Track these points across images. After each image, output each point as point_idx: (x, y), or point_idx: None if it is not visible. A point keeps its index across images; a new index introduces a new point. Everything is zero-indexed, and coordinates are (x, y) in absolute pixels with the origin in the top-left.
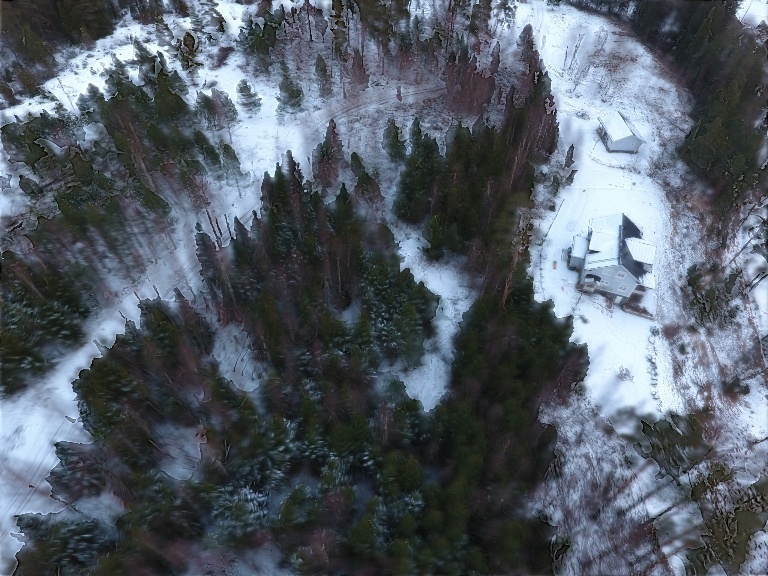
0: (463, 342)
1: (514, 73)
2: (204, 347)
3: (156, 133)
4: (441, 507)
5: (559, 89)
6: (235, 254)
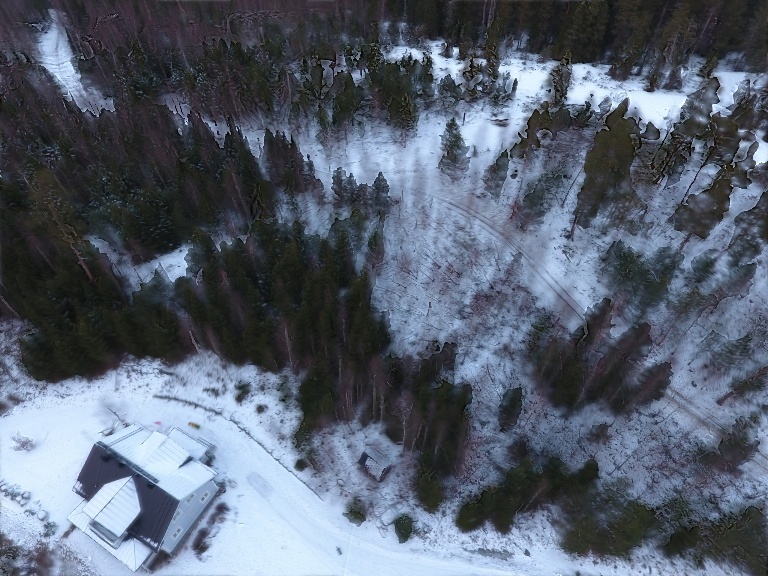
0: None
1: None
2: (177, 152)
3: (345, 86)
4: None
5: None
6: None
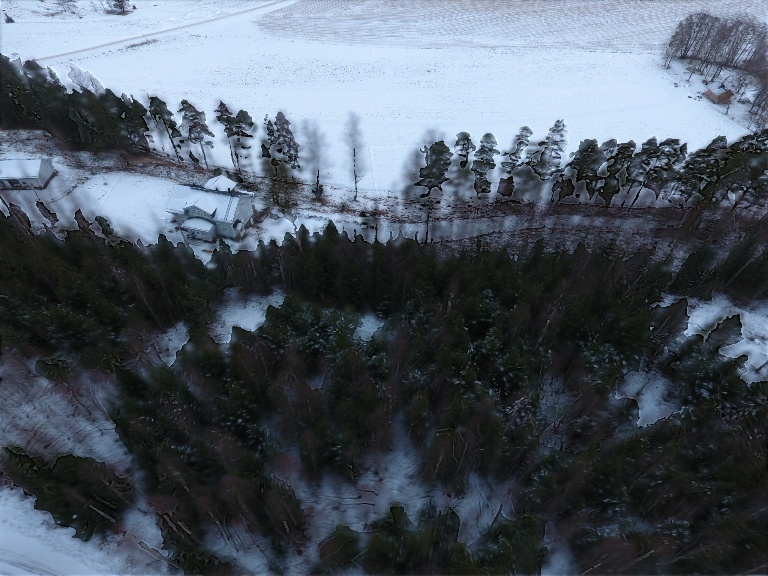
0: (346, 278)
1: None
2: None
3: None
4: (489, 280)
5: None
6: (248, 483)
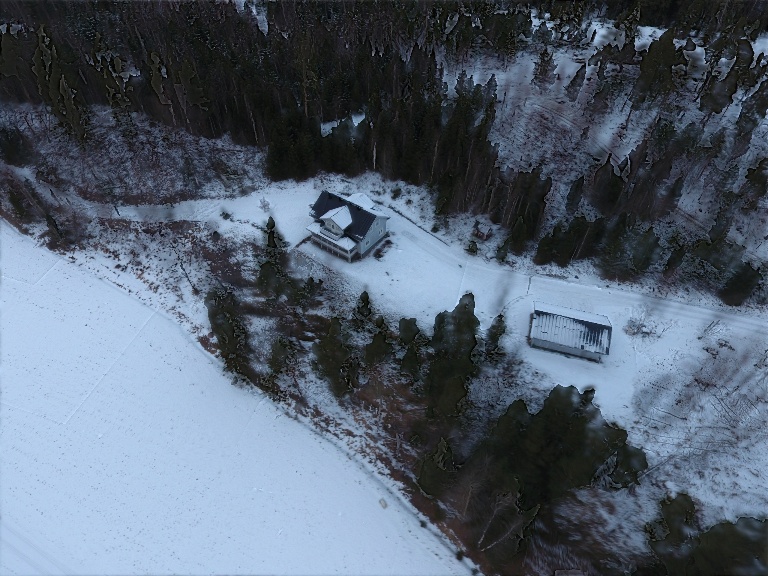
0: None
1: (759, 287)
2: None
3: None
4: None
5: (727, 332)
6: None
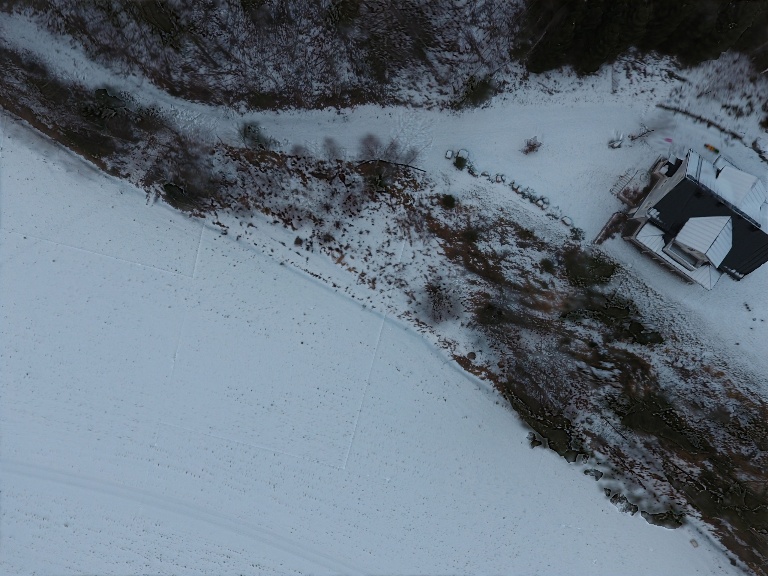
0: None
1: None
2: None
3: None
4: None
5: None
6: None
